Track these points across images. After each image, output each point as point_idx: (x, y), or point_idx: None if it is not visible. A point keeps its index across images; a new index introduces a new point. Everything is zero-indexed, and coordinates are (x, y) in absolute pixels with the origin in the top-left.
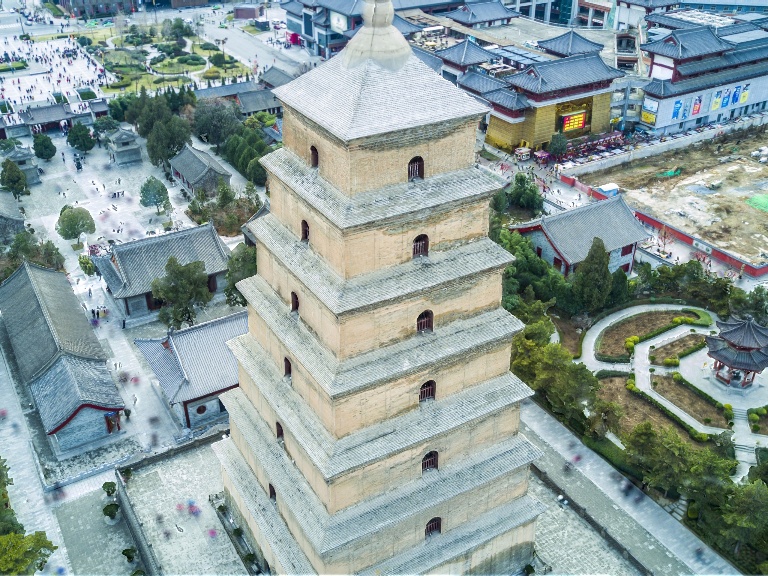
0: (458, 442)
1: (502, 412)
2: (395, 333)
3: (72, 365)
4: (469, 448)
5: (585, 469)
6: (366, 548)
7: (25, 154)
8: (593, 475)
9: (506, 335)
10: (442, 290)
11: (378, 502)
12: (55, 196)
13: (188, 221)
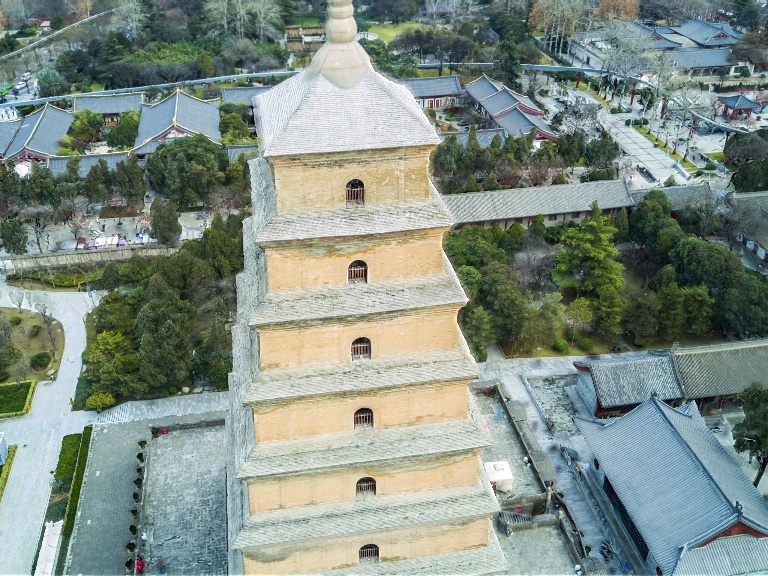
0: None
1: None
2: None
3: (655, 363)
4: None
5: None
6: None
7: None
8: None
9: None
10: None
11: None
12: None
13: None
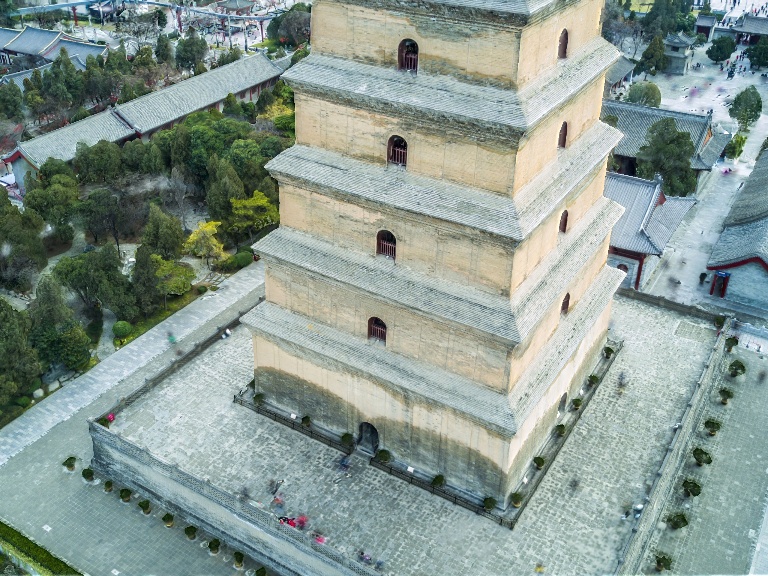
0: (422, 244)
1: (485, 244)
2: (371, 50)
3: None
4: (436, 264)
5: (766, 552)
6: (304, 289)
7: (682, 41)
8: (764, 564)
9: (498, 127)
10: (430, 19)
11: (323, 246)
12: (677, 87)
13: (757, 145)
